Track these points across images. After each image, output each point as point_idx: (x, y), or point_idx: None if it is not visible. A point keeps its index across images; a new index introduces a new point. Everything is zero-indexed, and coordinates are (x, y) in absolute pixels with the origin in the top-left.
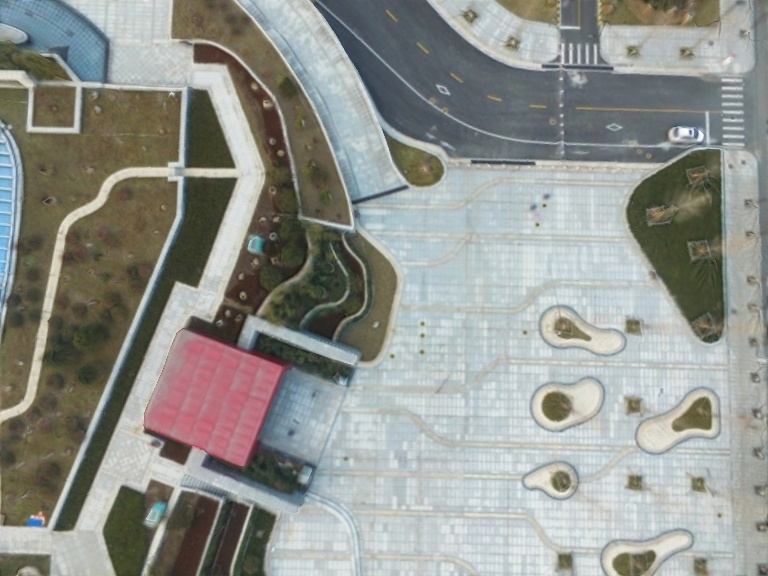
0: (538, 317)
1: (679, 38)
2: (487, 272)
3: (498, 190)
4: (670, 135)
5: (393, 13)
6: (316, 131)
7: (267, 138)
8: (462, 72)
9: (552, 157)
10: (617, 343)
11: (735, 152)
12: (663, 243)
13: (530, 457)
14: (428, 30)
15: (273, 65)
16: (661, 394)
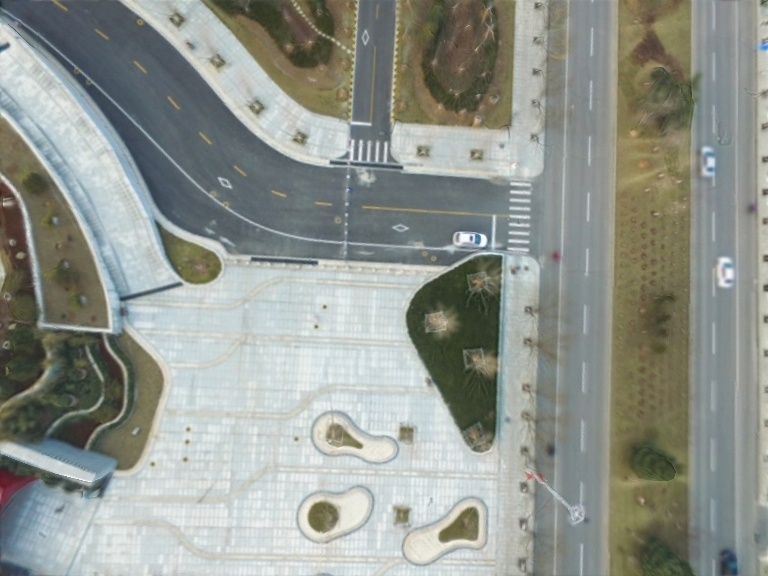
0: (311, 423)
1: (470, 140)
2: (261, 375)
3: (278, 289)
4: (454, 239)
5: (175, 100)
6: (72, 228)
7: (7, 238)
8: (246, 165)
9: (336, 256)
10: (388, 451)
11: (519, 257)
12: (439, 350)
13: (293, 570)
14: (212, 120)
15: (21, 158)
16: (430, 504)
